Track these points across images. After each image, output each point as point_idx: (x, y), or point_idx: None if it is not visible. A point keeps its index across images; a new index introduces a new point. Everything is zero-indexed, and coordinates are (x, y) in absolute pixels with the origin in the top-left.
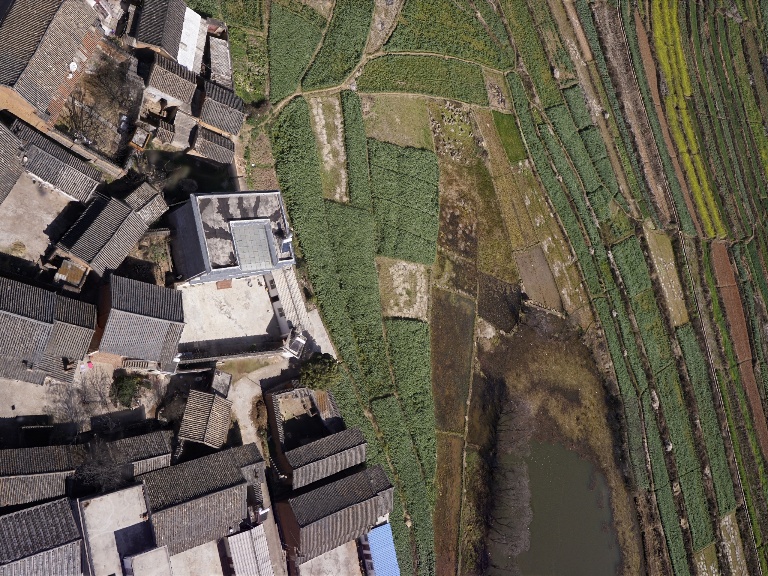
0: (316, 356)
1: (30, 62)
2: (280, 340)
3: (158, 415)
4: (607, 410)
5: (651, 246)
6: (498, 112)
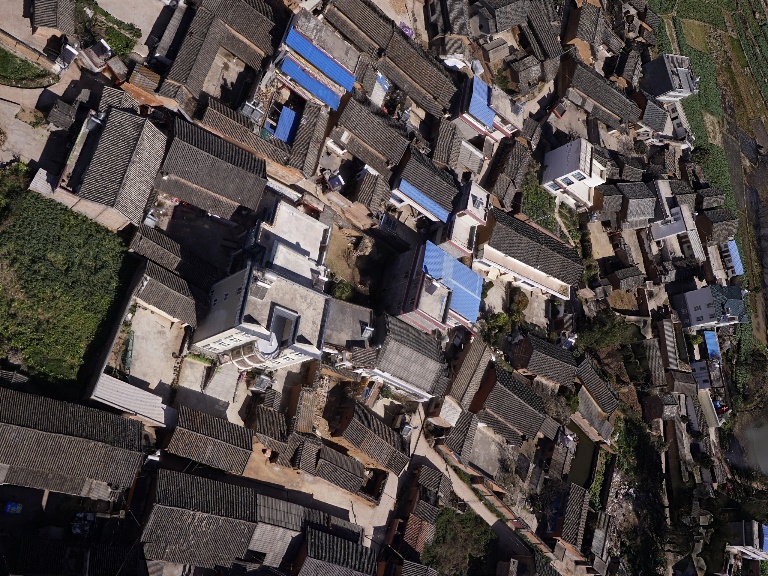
0: (699, 147)
1: None
2: None
3: (650, 162)
4: None
5: None
6: (732, 37)
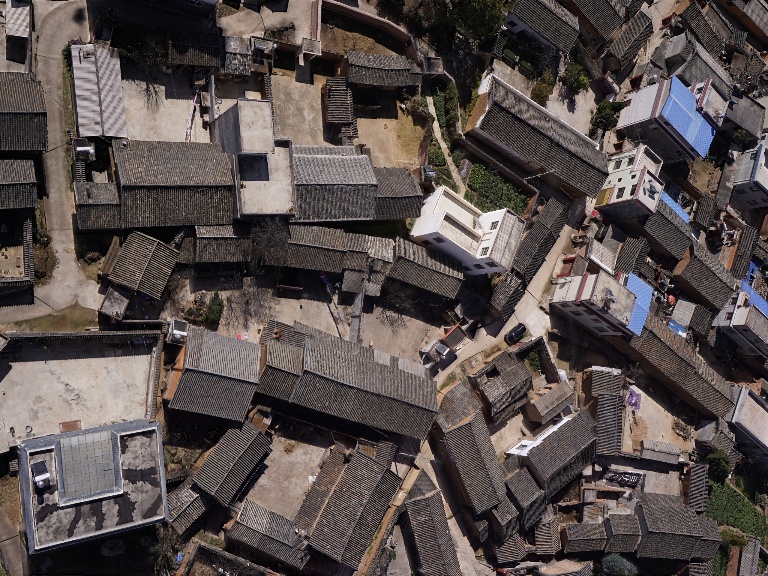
0: None
1: None
2: None
3: None
4: None
5: None
6: None
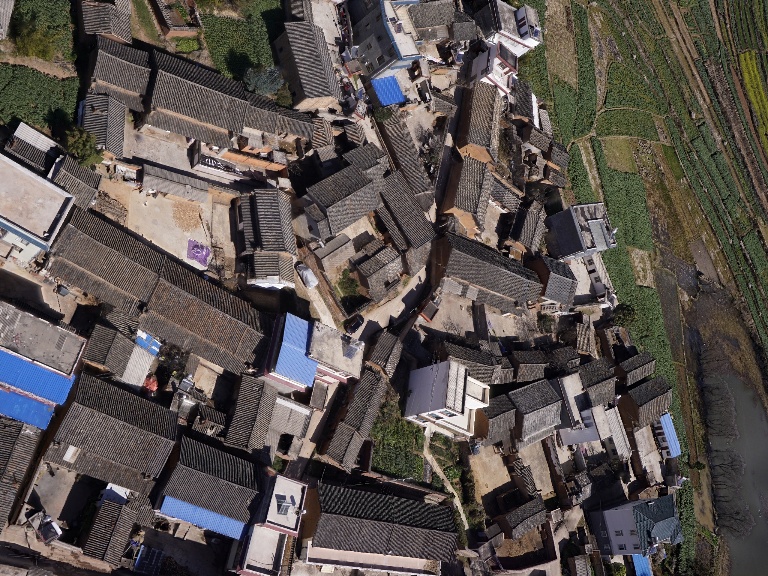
0: (622, 306)
1: (491, 133)
2: (596, 298)
3: (559, 339)
4: (755, 354)
5: (764, 237)
6: (664, 145)
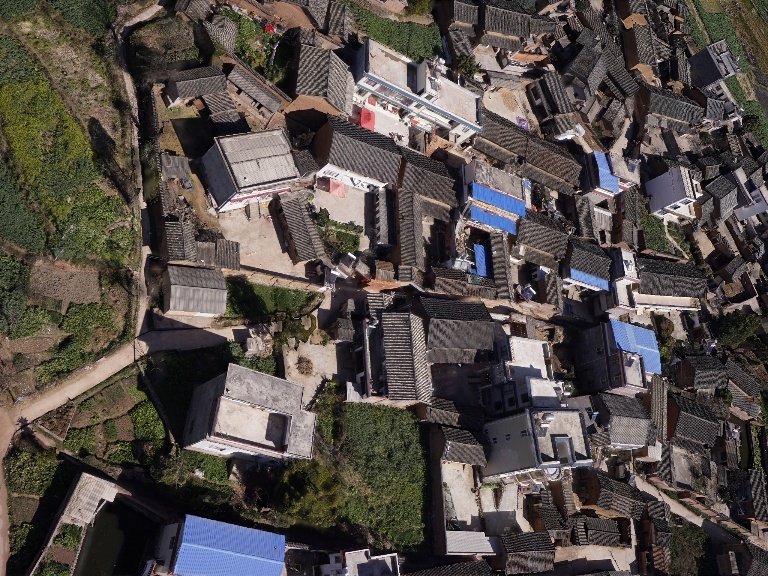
0: (748, 116)
1: None
2: (727, 115)
3: None
4: None
5: None
6: None
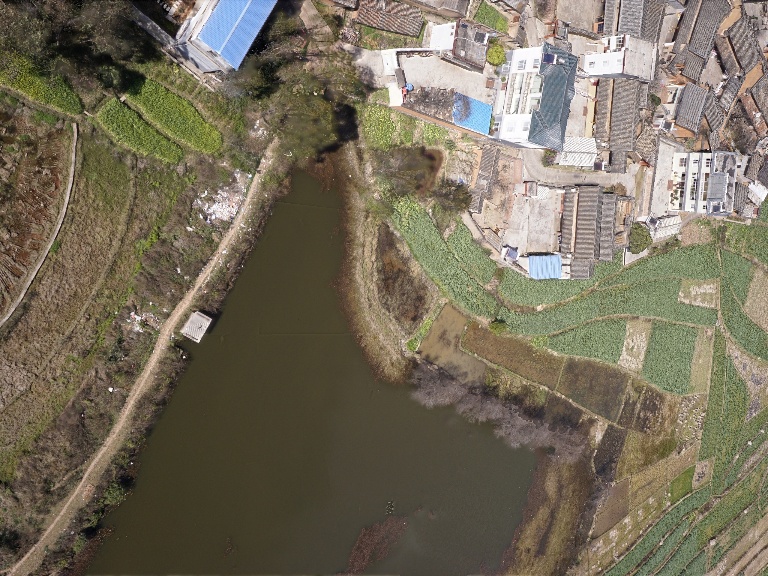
0: None
1: None
2: None
3: None
4: None
5: None
6: (694, 472)
